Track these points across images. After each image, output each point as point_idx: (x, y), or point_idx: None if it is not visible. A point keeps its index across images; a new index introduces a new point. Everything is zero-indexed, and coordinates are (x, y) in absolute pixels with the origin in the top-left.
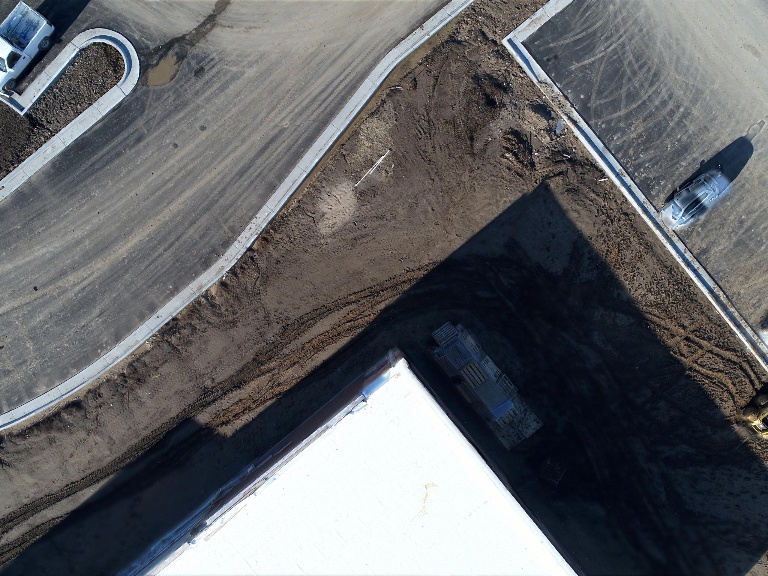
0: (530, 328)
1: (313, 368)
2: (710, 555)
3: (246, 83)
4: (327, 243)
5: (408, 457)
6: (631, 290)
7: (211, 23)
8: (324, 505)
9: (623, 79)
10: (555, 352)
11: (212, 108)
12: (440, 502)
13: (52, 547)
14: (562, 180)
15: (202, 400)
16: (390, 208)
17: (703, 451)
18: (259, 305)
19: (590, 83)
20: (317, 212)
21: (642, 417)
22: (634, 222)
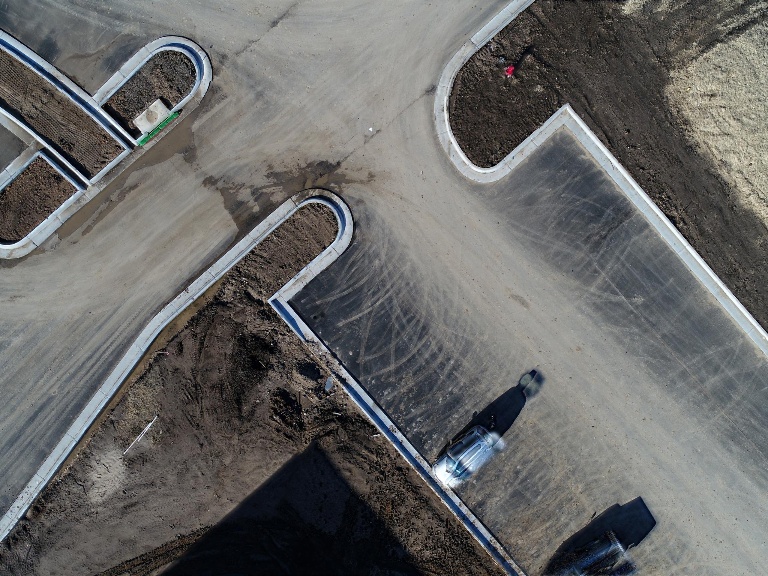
0: None
1: None
2: None
3: (13, 353)
4: (97, 512)
5: None
6: (406, 546)
7: None
8: None
9: (392, 334)
10: None
11: None
12: None
13: None
14: (333, 439)
15: None
16: (159, 475)
17: None
18: (32, 575)
19: (358, 339)
20: (87, 481)
21: None
22: (408, 476)
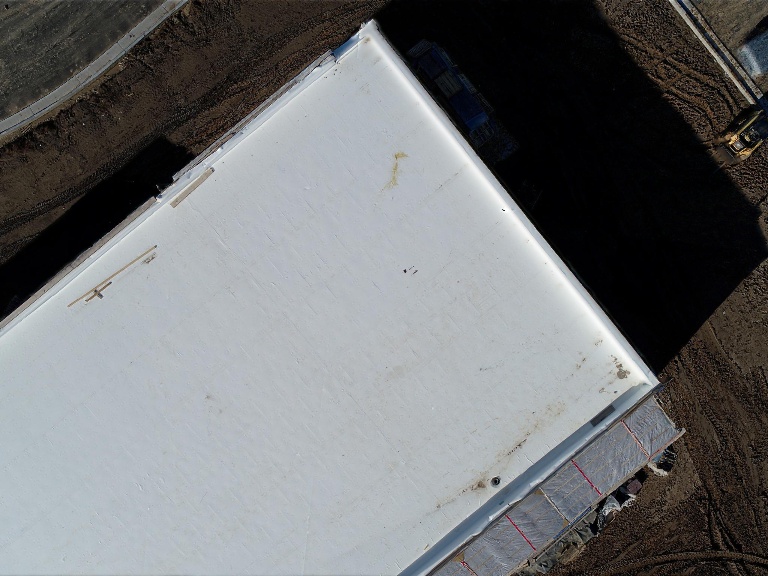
0: (506, 48)
1: None
2: (687, 282)
3: None
4: None
5: (378, 125)
6: (608, 11)
7: None
8: (293, 173)
9: None
10: (531, 73)
11: None
12: (410, 173)
13: (24, 267)
14: None
15: (175, 119)
16: None
17: (680, 175)
18: (232, 23)
19: None
20: None
21: (619, 139)
22: None
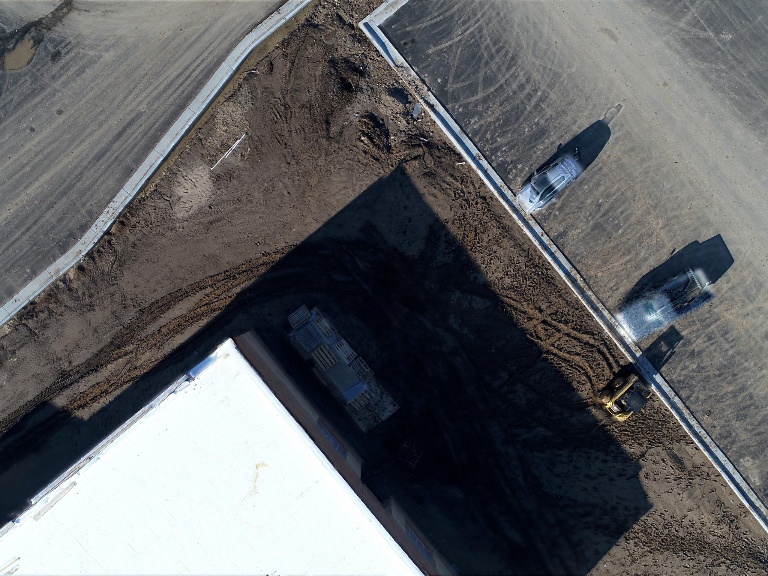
0: (386, 311)
1: (170, 351)
2: (568, 537)
3: (103, 67)
4: (183, 227)
5: (238, 437)
6: (488, 273)
7: (67, 7)
8: (154, 485)
9: (480, 63)
10: (411, 335)
11: (69, 92)
12: (271, 482)
13: None
14: (419, 164)
15: (59, 383)
16: (246, 192)
17: (560, 433)
18: (116, 289)
19: (447, 67)
20: (173, 196)
21: (498, 400)
22: (492, 206)
